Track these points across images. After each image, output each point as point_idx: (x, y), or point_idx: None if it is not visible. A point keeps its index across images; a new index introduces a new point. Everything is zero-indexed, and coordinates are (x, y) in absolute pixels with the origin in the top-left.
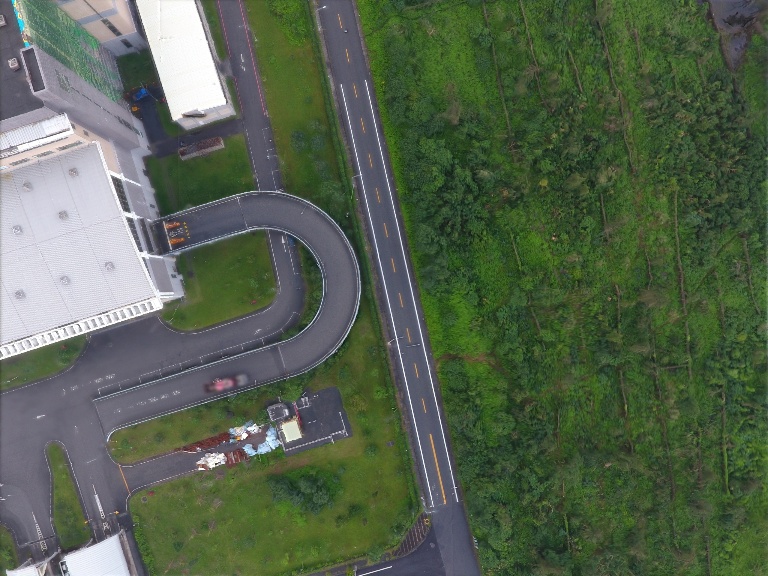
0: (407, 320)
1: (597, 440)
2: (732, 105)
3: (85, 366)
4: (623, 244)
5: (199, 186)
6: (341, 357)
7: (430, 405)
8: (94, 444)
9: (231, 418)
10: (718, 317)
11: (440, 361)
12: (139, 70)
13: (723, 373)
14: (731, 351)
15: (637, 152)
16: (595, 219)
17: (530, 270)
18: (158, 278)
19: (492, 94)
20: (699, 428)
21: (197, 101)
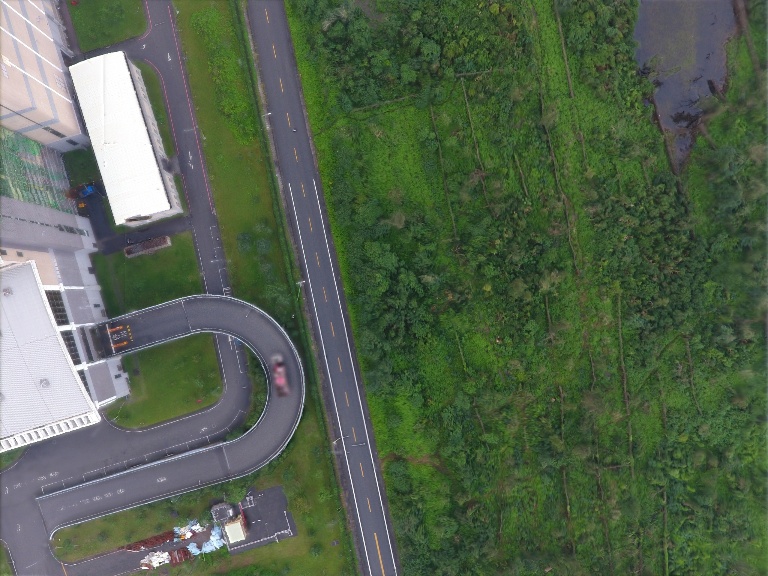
0: (353, 419)
1: (539, 541)
2: (675, 208)
3: (28, 464)
4: (567, 345)
5: (145, 284)
6: (286, 458)
7: (375, 504)
8: (37, 542)
9: (175, 518)
10: (660, 417)
11: (385, 460)
12: (86, 166)
13: (665, 472)
14: (673, 451)
15: (582, 254)
16: (538, 323)
17: (474, 372)
18: (98, 386)
19: (439, 196)
20: (640, 528)
21: (140, 207)
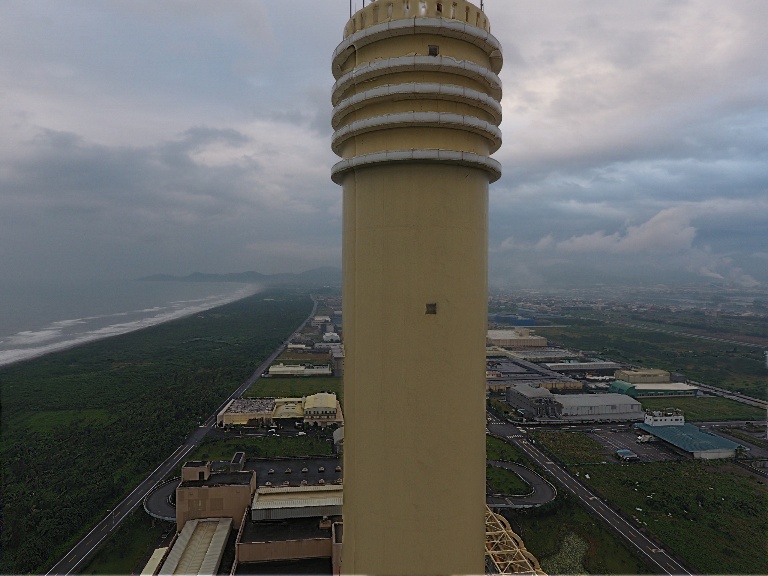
0: None
1: None
2: None
3: None
4: None
5: None
6: None
7: None
8: None
9: None
10: None
11: None
12: None
13: None
14: None
15: None
16: None
17: None
18: None
19: None
20: None
21: None
